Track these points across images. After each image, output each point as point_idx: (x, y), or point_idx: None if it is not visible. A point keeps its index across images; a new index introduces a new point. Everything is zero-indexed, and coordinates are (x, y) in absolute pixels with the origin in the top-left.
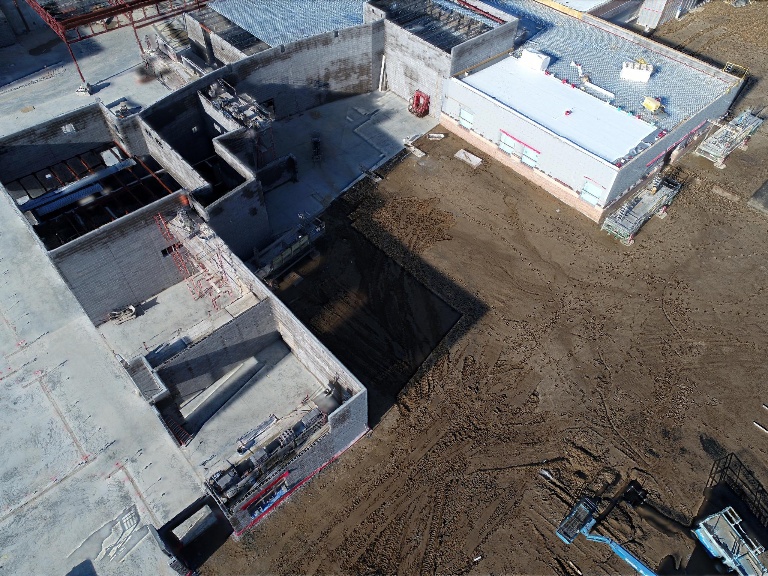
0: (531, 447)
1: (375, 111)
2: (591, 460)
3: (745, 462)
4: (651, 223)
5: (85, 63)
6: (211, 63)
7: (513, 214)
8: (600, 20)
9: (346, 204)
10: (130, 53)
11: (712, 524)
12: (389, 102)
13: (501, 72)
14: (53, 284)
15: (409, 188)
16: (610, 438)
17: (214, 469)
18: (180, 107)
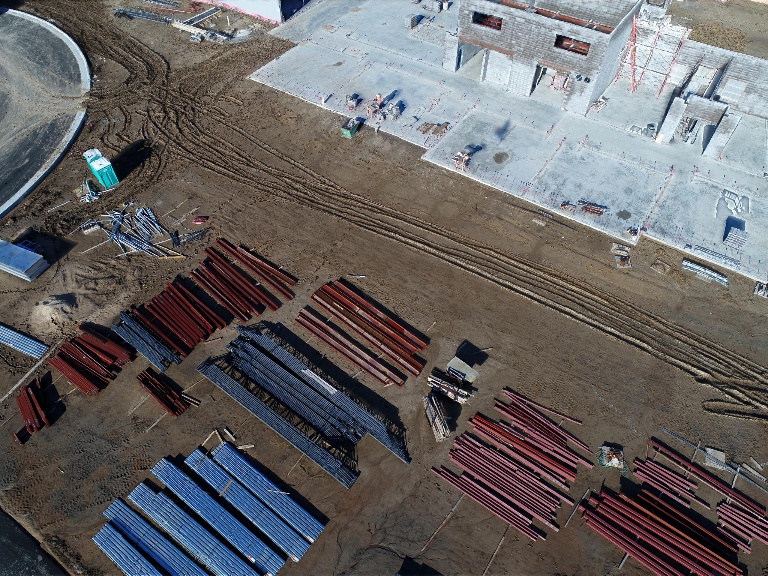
0: None
1: None
2: None
3: None
4: None
5: None
6: None
7: None
8: None
9: None
10: None
11: None
12: None
13: None
14: (522, 100)
15: (694, 19)
16: None
17: None
18: None
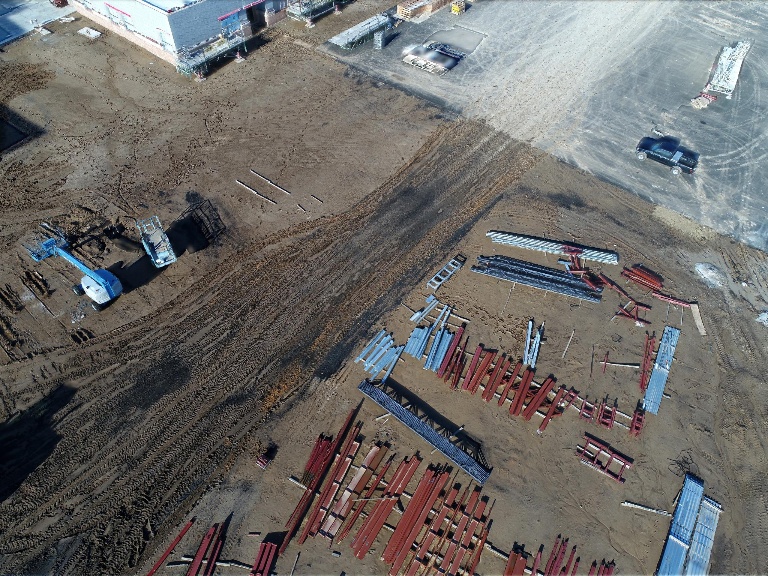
0: (42, 211)
1: (20, 5)
2: (88, 213)
3: (214, 204)
4: (228, 66)
5: None
6: None
7: (110, 68)
8: None
9: None
10: None
11: (150, 233)
12: None
13: None
14: None
15: (25, 57)
16: (113, 200)
17: None
18: None
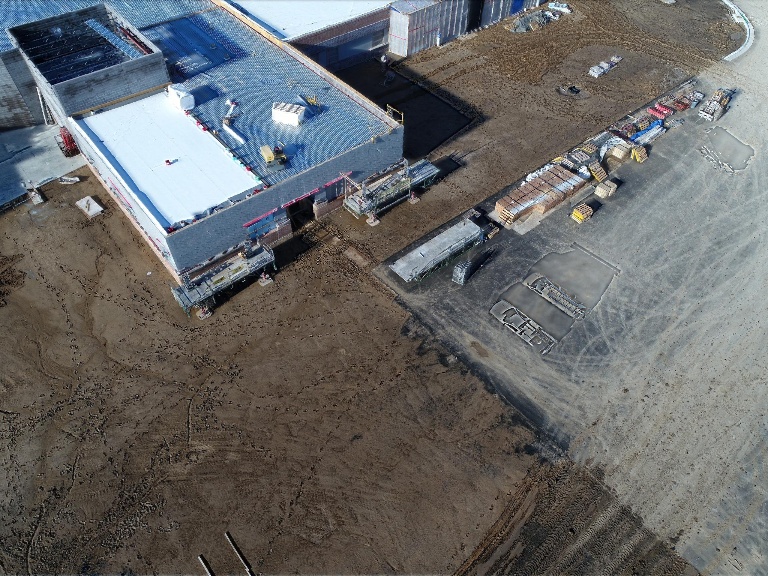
0: None
1: (24, 148)
2: None
3: None
4: (247, 291)
5: None
6: None
7: (95, 276)
8: (295, 51)
9: None
10: None
11: None
12: (48, 138)
13: (136, 111)
14: None
15: None
16: (13, 572)
17: None
18: None
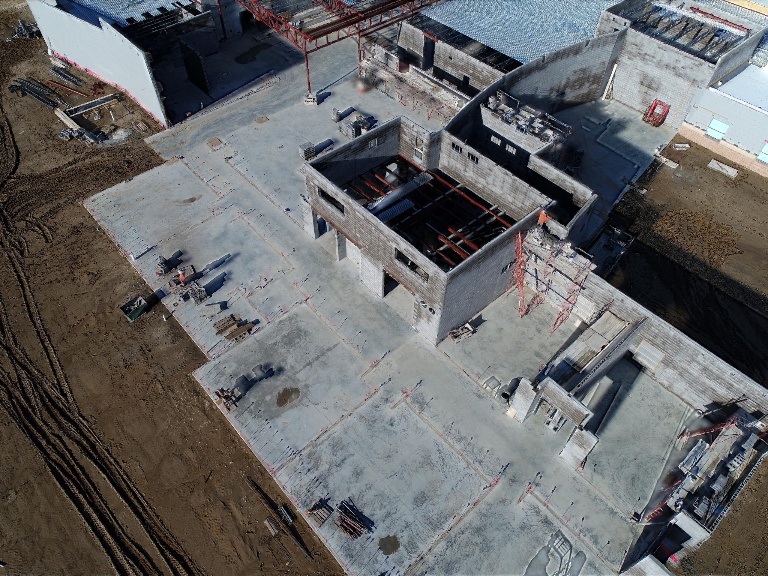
0: None
1: (608, 120)
2: None
3: None
4: None
5: (296, 72)
6: None
7: None
8: None
9: (623, 217)
10: (336, 61)
11: None
12: (618, 111)
13: (751, 81)
14: (371, 301)
15: (677, 200)
16: None
17: None
18: (465, 120)
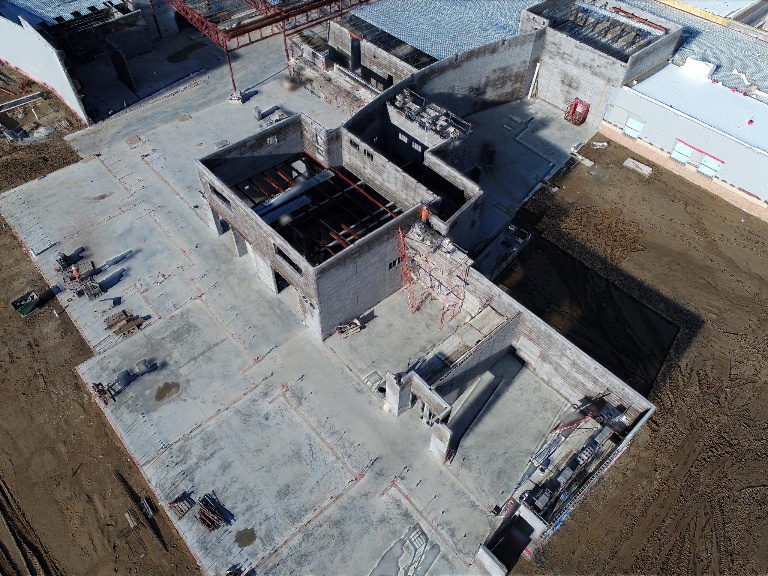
0: None
1: (530, 119)
2: None
3: None
4: None
5: (227, 71)
6: (352, 70)
7: (699, 224)
8: (748, 26)
9: (531, 214)
10: (268, 60)
11: None
12: (541, 110)
13: (668, 80)
14: (266, 297)
15: (587, 198)
16: None
17: (520, 489)
18: (370, 117)
